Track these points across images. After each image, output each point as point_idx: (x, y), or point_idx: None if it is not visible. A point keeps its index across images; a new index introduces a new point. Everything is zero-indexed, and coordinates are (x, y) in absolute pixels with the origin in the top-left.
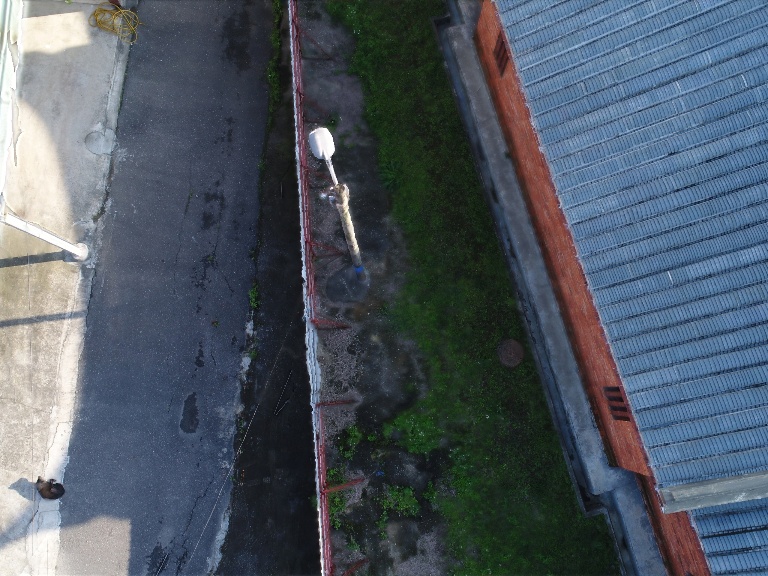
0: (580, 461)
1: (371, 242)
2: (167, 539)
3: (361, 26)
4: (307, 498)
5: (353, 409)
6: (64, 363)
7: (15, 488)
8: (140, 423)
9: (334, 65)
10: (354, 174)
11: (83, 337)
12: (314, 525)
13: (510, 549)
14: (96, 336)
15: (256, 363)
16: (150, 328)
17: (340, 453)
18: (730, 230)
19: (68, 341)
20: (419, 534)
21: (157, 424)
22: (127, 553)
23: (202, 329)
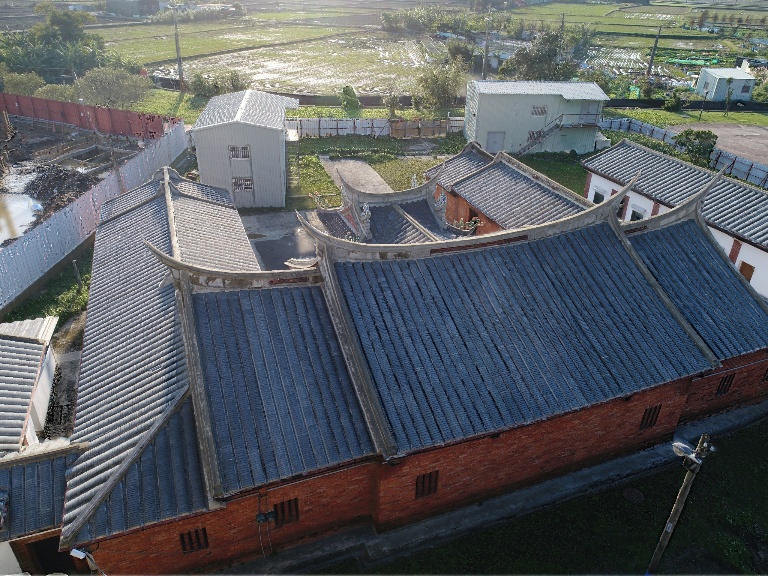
0: (677, 459)
1: None
2: None
3: None
4: None
5: None
6: None
7: None
8: None
9: None
10: None
11: None
12: None
13: (765, 489)
14: None
15: None
16: None
17: None
18: None
19: None
20: None
21: None
22: None
23: None
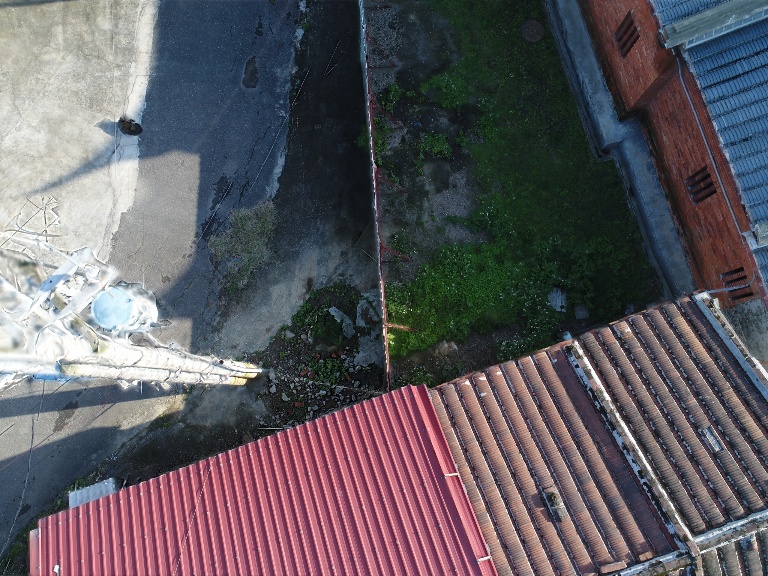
0: (593, 124)
1: None
2: (231, 171)
3: None
4: (353, 142)
5: (393, 72)
6: (141, 29)
7: (99, 126)
8: (207, 78)
9: None
10: None
11: (157, 9)
12: (359, 163)
13: (531, 185)
14: (168, 9)
15: (308, 34)
16: (216, 3)
17: (382, 107)
18: None
19: (144, 12)
20: (451, 172)
21: (222, 79)
22: (197, 180)
23: (261, 6)
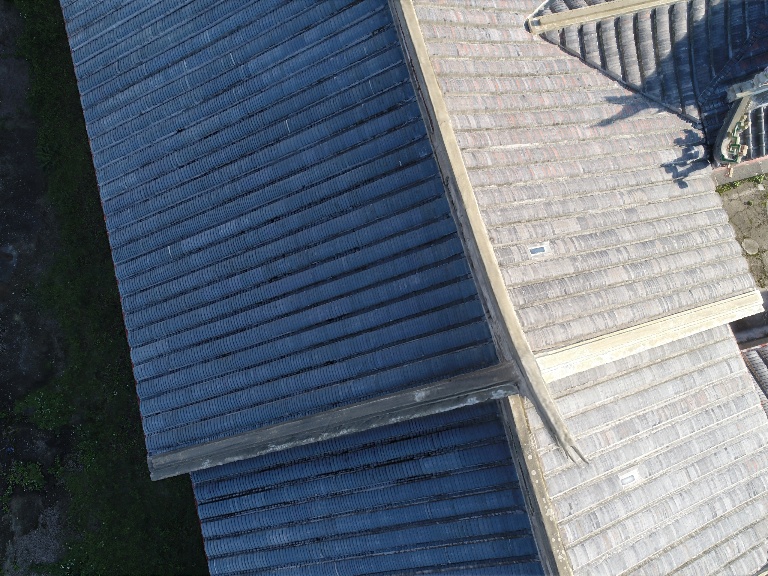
0: None
1: (23, 223)
2: None
3: (30, 10)
4: None
5: None
6: None
7: None
8: None
9: (3, 48)
10: (12, 156)
11: None
12: None
13: (131, 522)
14: None
15: None
16: None
17: None
18: (217, 205)
19: None
20: (42, 508)
21: None
22: None
23: None
